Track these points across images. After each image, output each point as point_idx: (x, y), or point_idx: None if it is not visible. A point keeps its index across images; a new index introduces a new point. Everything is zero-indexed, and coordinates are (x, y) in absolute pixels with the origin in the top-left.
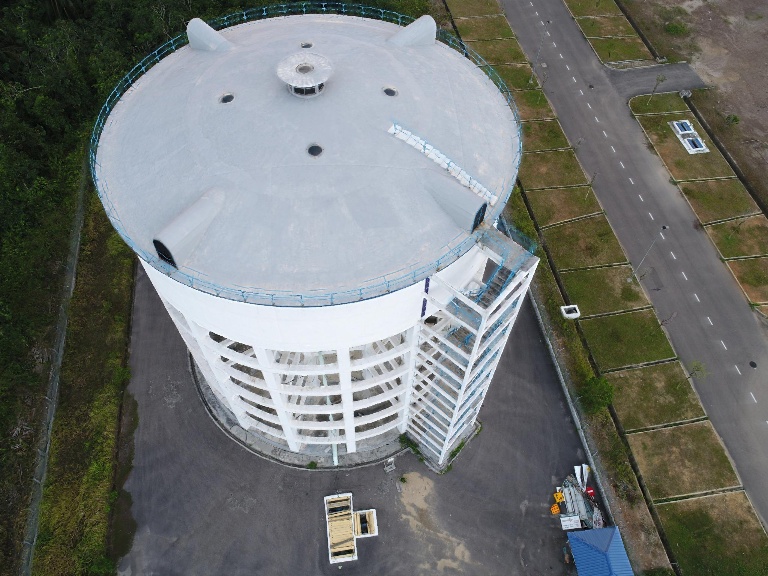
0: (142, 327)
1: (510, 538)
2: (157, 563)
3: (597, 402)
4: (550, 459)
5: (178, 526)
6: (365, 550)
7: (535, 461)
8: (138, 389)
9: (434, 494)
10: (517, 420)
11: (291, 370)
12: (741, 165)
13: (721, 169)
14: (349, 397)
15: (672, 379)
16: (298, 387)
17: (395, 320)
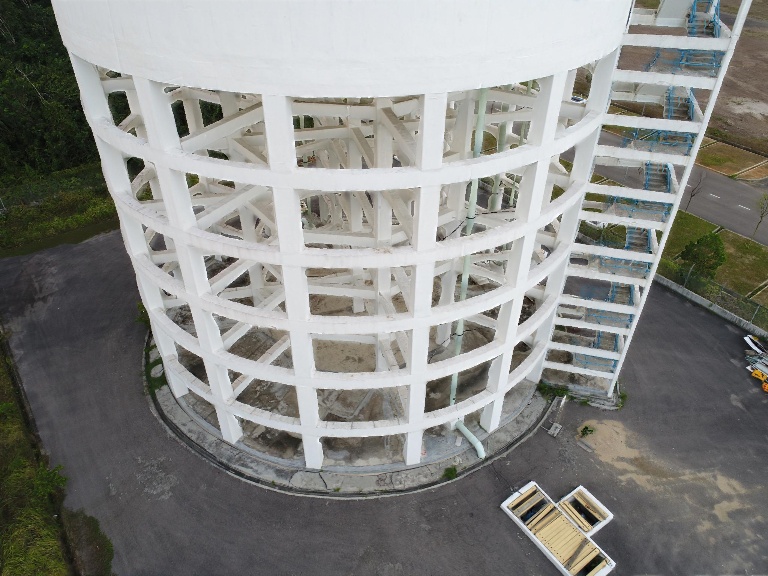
0: (54, 414)
1: (759, 441)
2: None
3: (712, 264)
4: (711, 345)
5: None
6: (614, 548)
7: (700, 353)
8: (87, 498)
9: (633, 434)
10: (643, 324)
11: (475, 163)
12: (623, 103)
13: (611, 109)
14: (530, 247)
15: (736, 243)
16: (463, 238)
17: (617, 6)
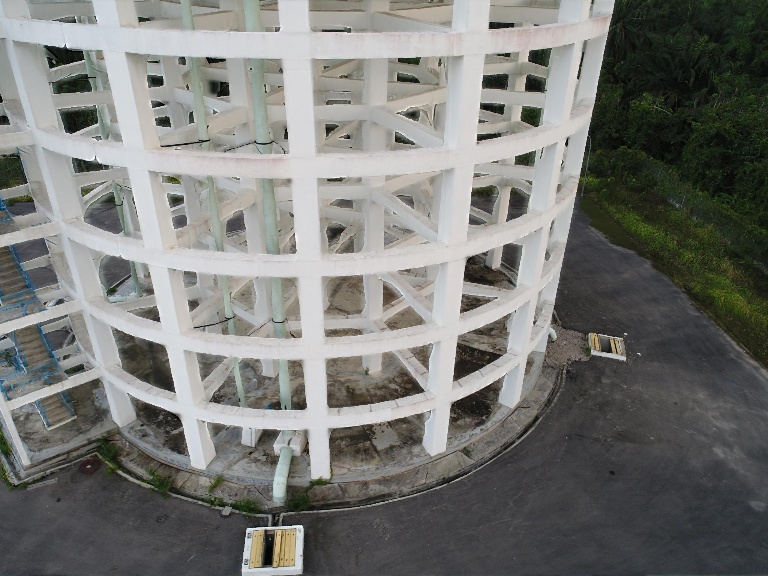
0: None
1: None
2: (92, 217)
3: None
4: None
5: (118, 224)
6: None
7: None
8: None
9: None
10: None
11: None
12: None
13: None
14: None
15: None
16: (75, 64)
17: None
